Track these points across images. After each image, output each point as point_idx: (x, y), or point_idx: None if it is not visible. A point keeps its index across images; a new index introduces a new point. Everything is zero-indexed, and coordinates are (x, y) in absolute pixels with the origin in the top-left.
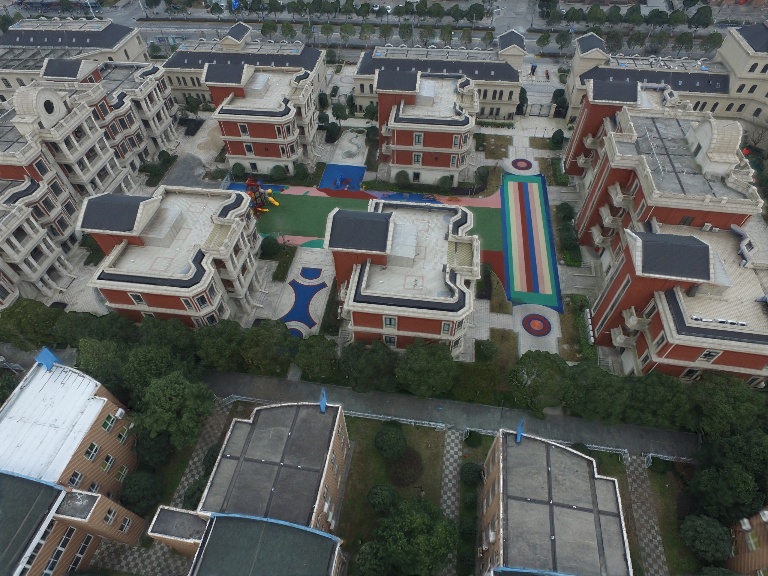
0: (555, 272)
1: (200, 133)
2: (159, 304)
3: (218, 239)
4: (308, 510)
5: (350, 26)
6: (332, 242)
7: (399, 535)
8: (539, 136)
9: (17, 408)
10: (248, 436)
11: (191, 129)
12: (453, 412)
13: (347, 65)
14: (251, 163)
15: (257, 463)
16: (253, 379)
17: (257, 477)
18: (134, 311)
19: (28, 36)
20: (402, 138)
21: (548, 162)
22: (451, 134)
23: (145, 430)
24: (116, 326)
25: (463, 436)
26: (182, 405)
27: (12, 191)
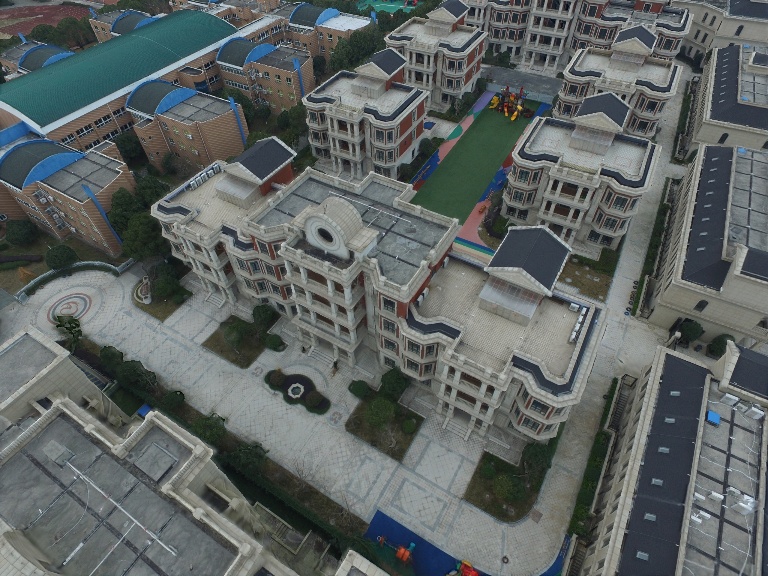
0: None
1: None
2: None
3: None
4: None
5: None
6: None
7: None
8: None
9: (357, 19)
10: None
11: None
12: None
13: None
14: None
15: None
16: None
17: None
18: None
19: None
20: None
21: None
22: None
23: None
24: None
25: None
26: None
27: None
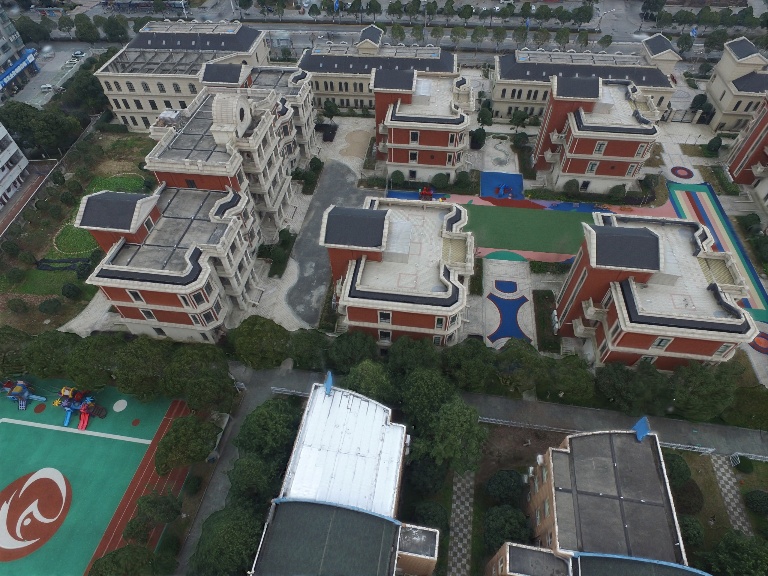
0: (760, 286)
1: (338, 139)
2: (405, 322)
3: (453, 254)
4: (672, 549)
5: (463, 28)
6: (599, 259)
7: (760, 574)
8: (689, 143)
9: (312, 435)
10: (570, 467)
11: (329, 135)
12: (710, 435)
13: (463, 68)
14: (411, 171)
15: (594, 496)
16: (487, 399)
17: (601, 512)
18: (373, 329)
19: (160, 39)
20: (582, 146)
21: (709, 170)
22: (638, 143)
23: (425, 456)
24: (367, 346)
25: (730, 461)
26: (466, 431)
27: (220, 202)
